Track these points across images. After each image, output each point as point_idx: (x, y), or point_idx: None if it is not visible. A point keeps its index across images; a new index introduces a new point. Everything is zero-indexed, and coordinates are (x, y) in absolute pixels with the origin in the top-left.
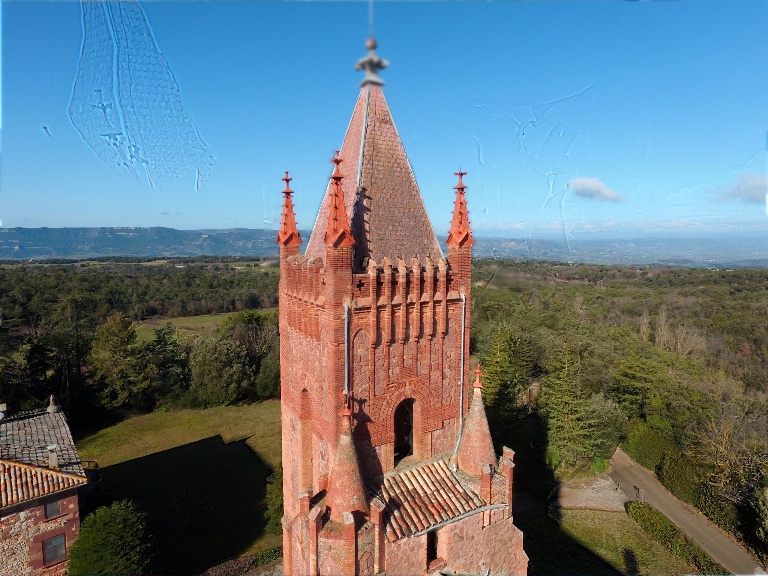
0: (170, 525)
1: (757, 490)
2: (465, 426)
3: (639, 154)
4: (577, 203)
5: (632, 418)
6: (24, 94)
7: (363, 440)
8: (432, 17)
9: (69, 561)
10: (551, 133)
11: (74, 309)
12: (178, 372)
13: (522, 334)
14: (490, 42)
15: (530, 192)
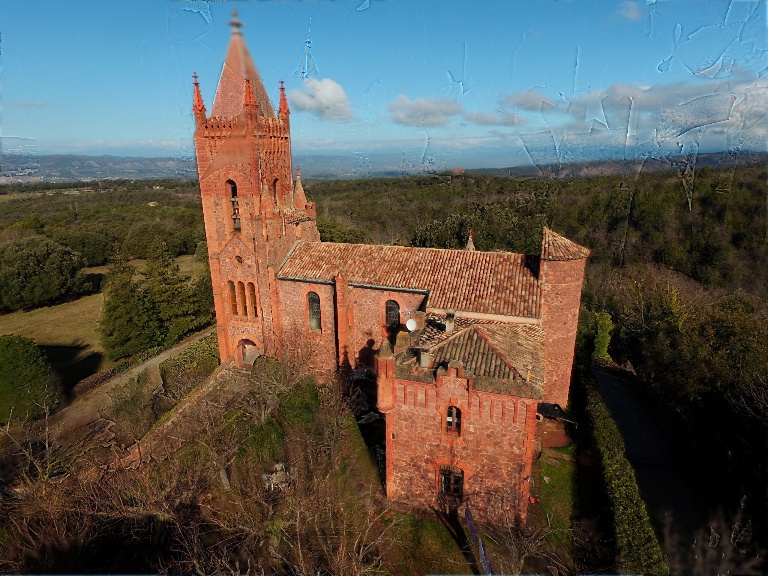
0: None
1: None
2: (295, 193)
3: None
4: None
5: None
6: (278, 61)
7: None
8: (343, 58)
9: None
10: None
11: None
12: None
13: None
14: None
15: None
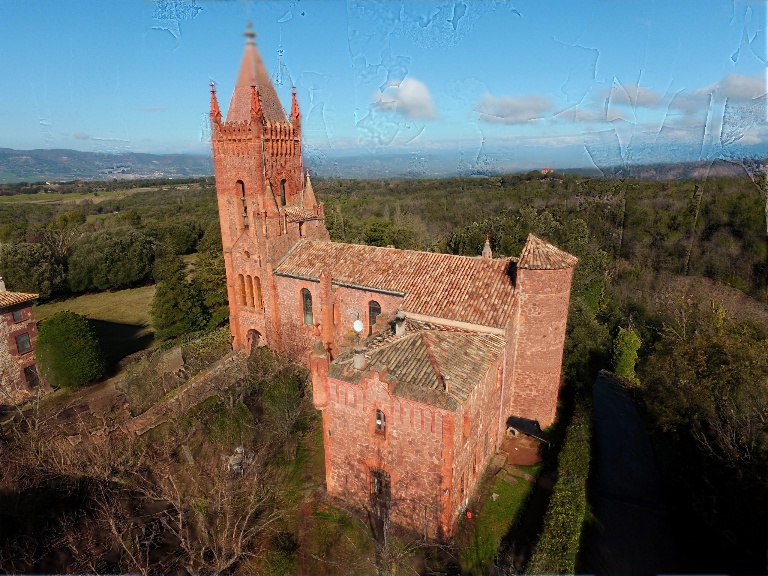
0: None
1: None
2: (305, 193)
3: None
4: (333, 111)
5: None
6: None
7: None
8: None
9: (35, 351)
10: None
11: None
12: None
13: None
14: (328, 68)
15: None
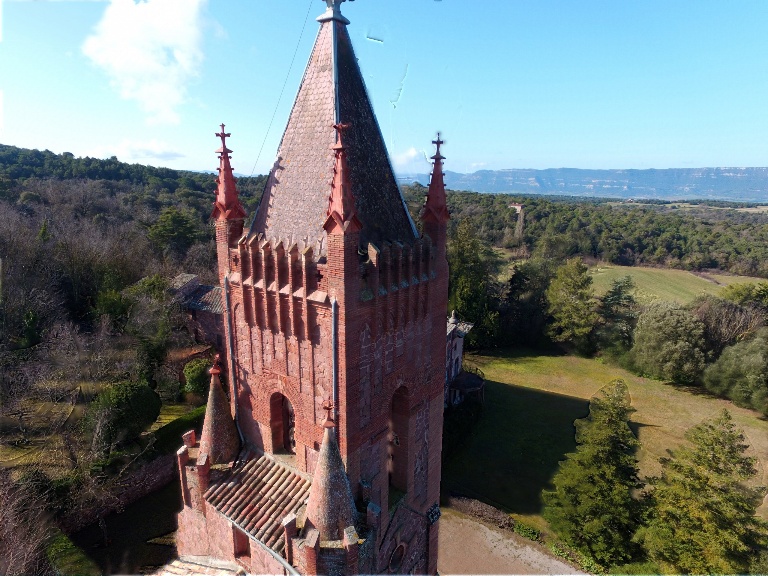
0: (501, 452)
1: None
2: None
3: None
4: None
5: None
6: None
7: (248, 408)
8: None
9: None
10: None
11: (549, 247)
12: (623, 329)
13: None
14: None
15: None
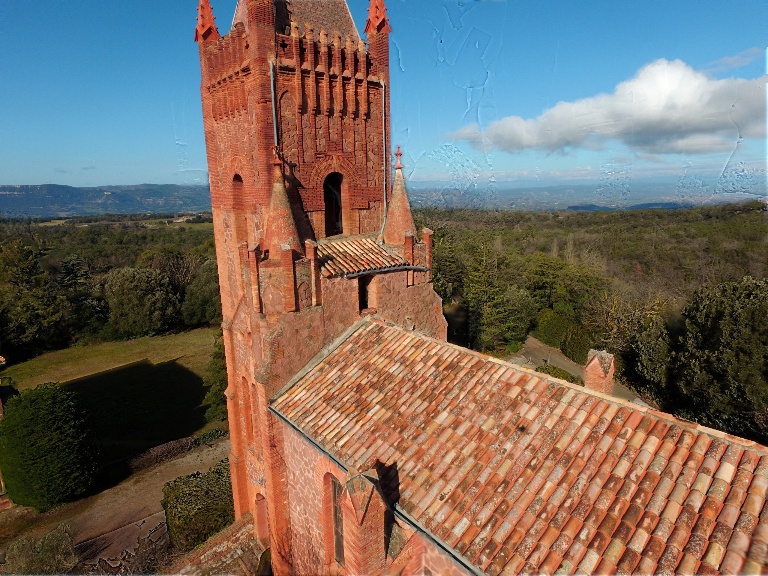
0: (103, 428)
1: (637, 333)
2: (389, 207)
3: (548, 72)
4: (492, 108)
5: (541, 309)
6: None
7: (295, 203)
8: None
9: None
10: (467, 45)
11: None
12: (93, 304)
13: (444, 233)
14: None
15: (450, 116)
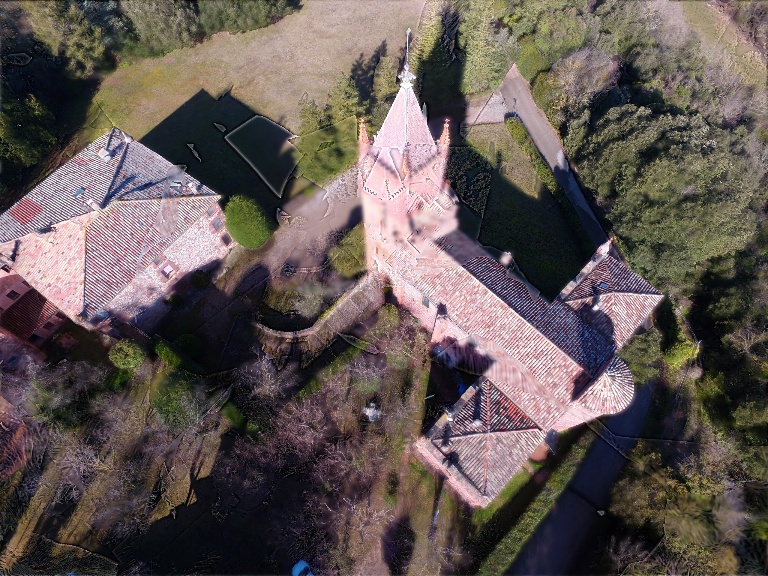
0: (234, 180)
1: (572, 120)
2: None
3: None
4: None
5: (526, 36)
6: None
7: None
8: None
9: (225, 226)
10: None
11: None
12: (120, 25)
13: None
14: None
15: None
